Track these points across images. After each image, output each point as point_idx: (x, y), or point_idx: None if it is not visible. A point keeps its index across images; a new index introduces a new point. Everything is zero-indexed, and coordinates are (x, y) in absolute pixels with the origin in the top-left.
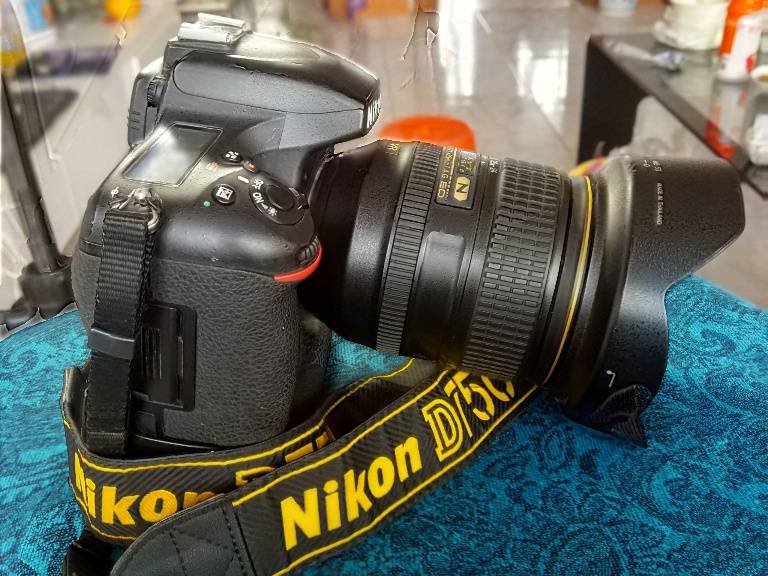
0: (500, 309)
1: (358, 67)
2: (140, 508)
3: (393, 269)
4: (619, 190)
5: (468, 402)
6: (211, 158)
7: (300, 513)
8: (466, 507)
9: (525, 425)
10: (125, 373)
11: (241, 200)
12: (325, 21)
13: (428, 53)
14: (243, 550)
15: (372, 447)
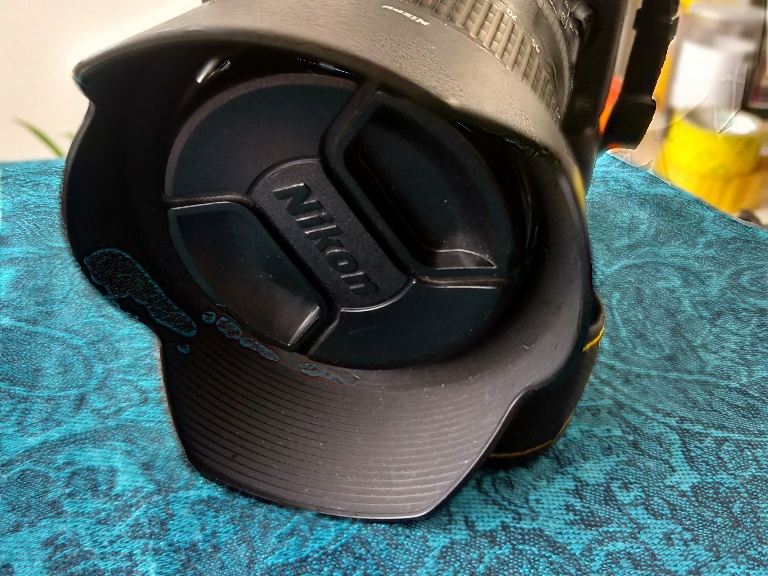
0: None
1: None
2: None
3: None
4: None
5: None
6: None
7: None
8: None
9: None
10: None
11: None
12: None
13: None
14: None
15: None
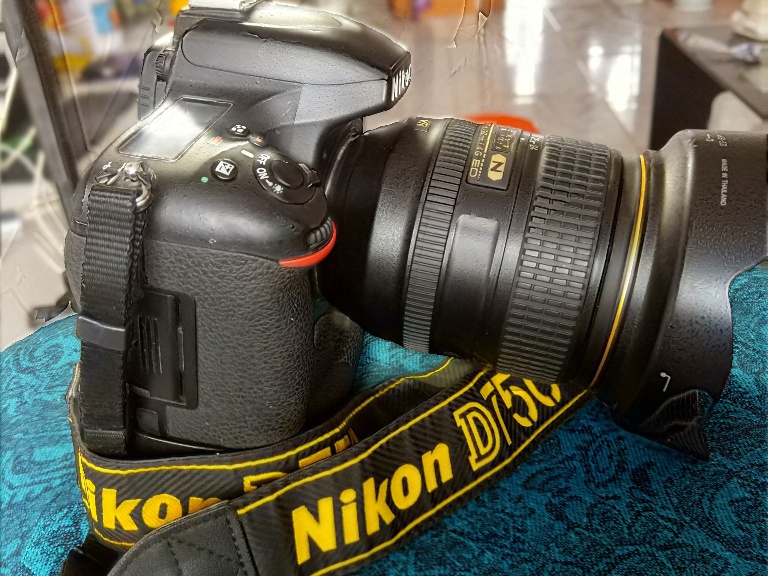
0: (538, 302)
1: (384, 36)
2: (143, 513)
3: (419, 256)
4: (677, 168)
5: (508, 406)
6: (216, 132)
7: (314, 524)
8: (501, 522)
9: (571, 433)
10: (118, 366)
11: (243, 176)
12: (370, 5)
13: (480, 39)
14: (249, 563)
15: (396, 453)
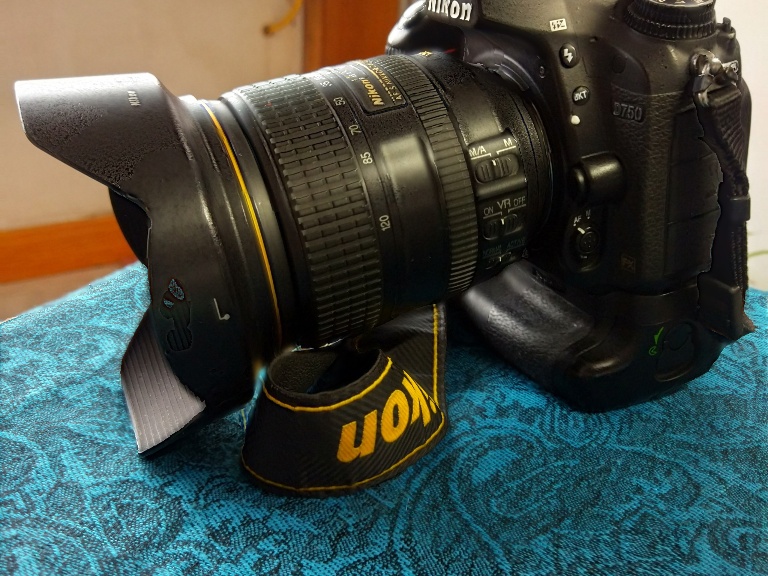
0: None
1: None
2: None
3: None
4: None
5: None
6: None
7: None
8: None
9: None
10: None
11: None
12: None
13: None
14: None
15: None
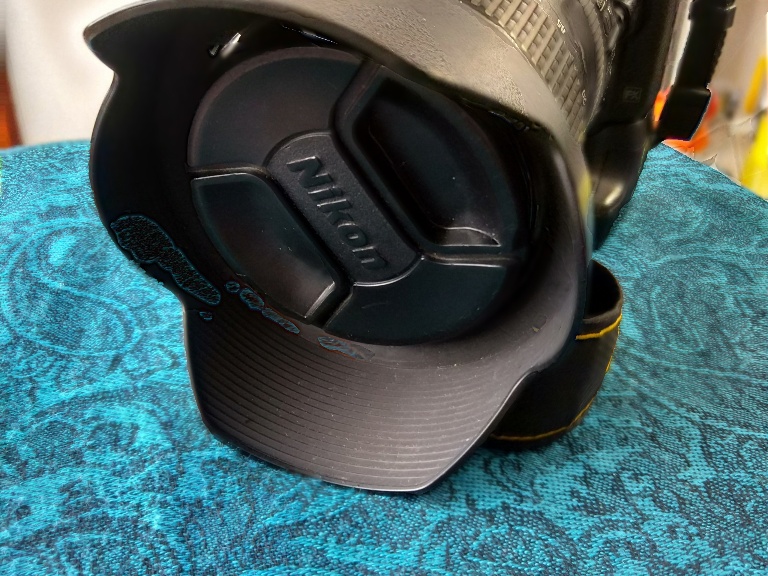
0: None
1: None
2: None
3: None
4: None
5: None
6: None
7: None
8: None
9: None
10: None
11: None
12: None
13: None
14: None
15: None
